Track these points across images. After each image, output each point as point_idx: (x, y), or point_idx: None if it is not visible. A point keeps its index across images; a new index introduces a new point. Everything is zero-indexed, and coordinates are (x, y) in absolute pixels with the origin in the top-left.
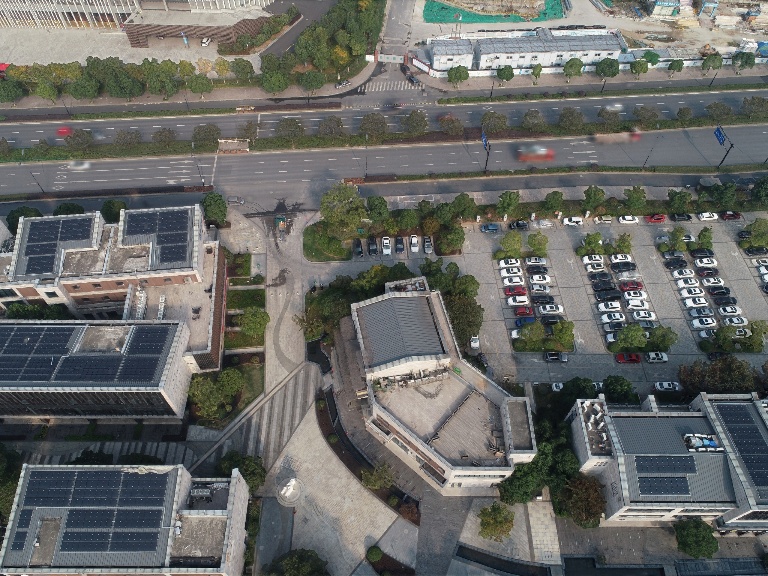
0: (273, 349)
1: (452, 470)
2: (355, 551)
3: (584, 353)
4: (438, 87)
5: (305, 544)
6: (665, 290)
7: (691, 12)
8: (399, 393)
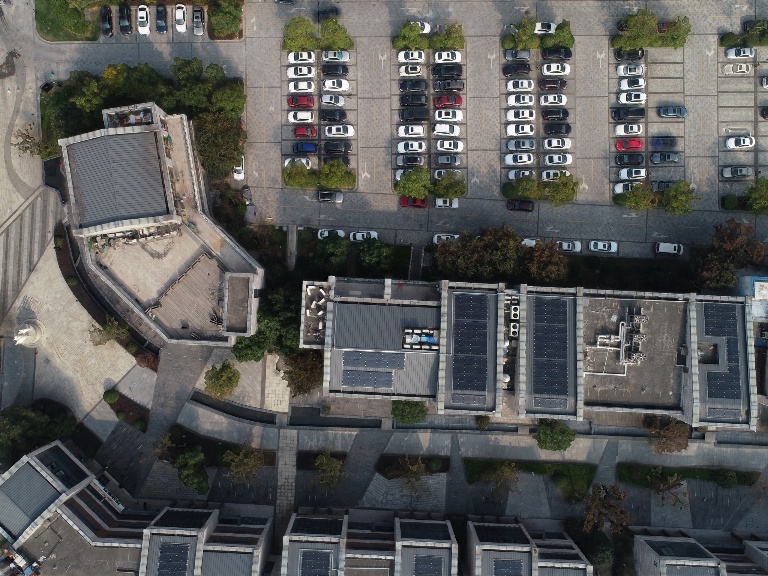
0: (4, 168)
1: (168, 342)
2: (95, 391)
3: (366, 192)
4: None
5: (47, 383)
6: (490, 108)
7: None
8: (123, 251)
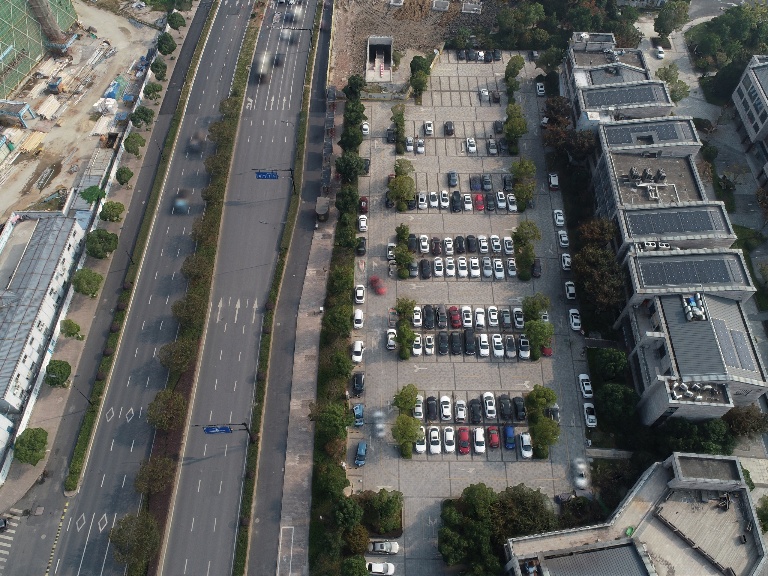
0: None
1: (767, 557)
2: None
3: (542, 385)
4: (29, 485)
5: None
6: (457, 288)
7: (18, 132)
8: None
